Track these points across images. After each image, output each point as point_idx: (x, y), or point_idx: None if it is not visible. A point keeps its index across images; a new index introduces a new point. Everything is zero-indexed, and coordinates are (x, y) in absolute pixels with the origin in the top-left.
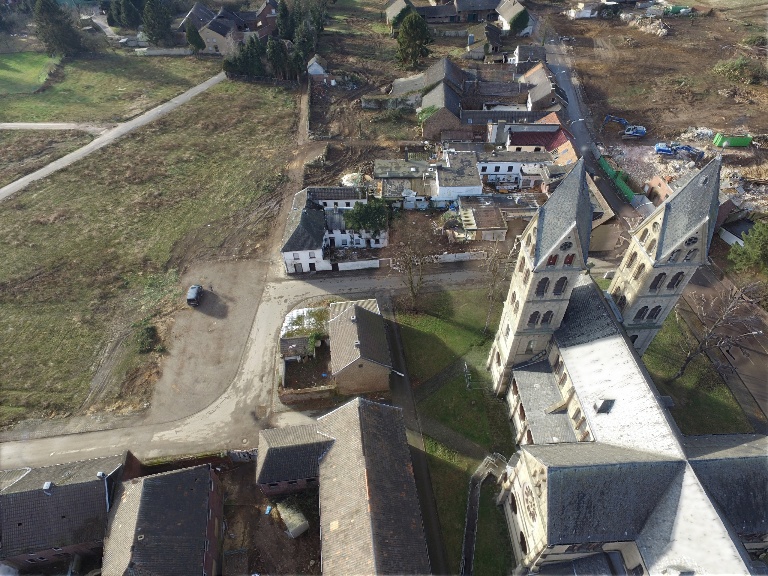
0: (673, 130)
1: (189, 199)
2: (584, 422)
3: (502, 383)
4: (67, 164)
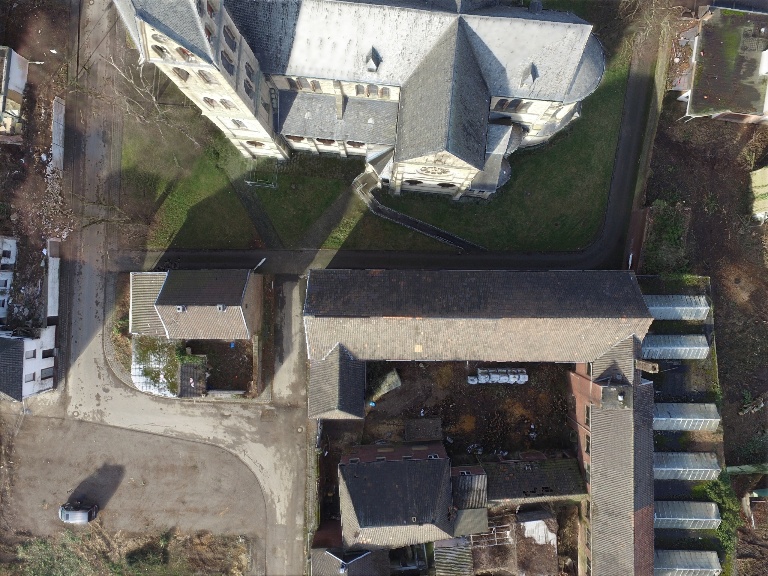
0: None
1: None
2: (370, 87)
3: (283, 150)
4: None
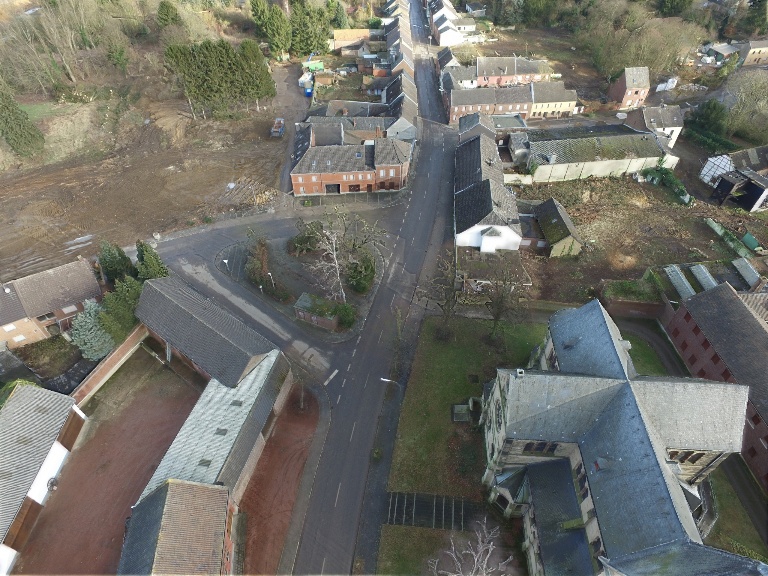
0: None
1: None
2: None
3: None
4: None
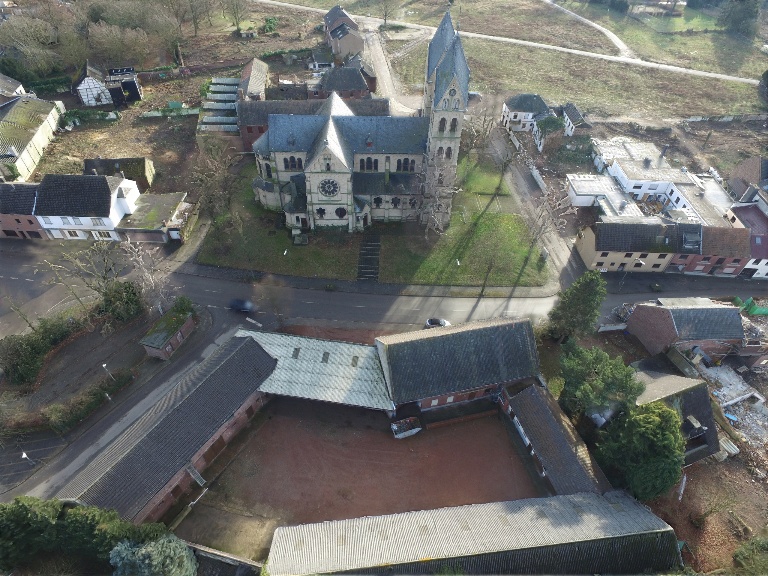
0: None
1: (562, 89)
2: None
3: None
4: (577, 53)
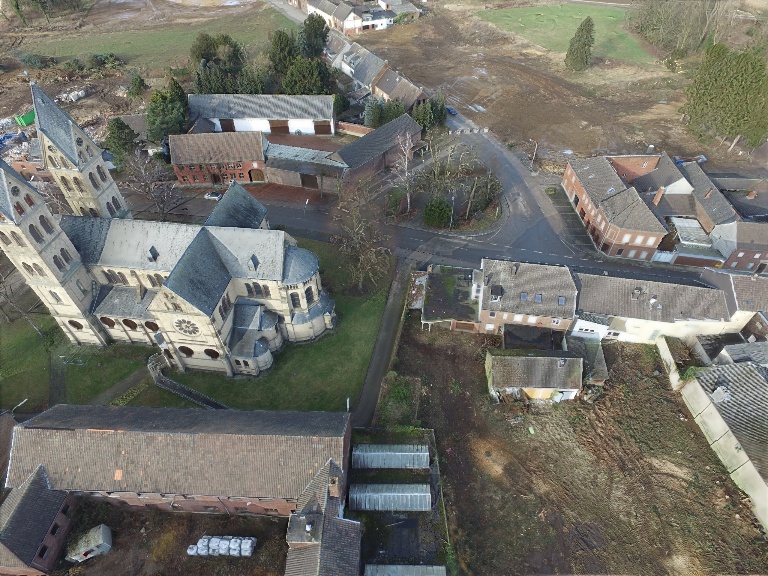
0: None
1: None
2: (158, 277)
3: (98, 332)
4: None
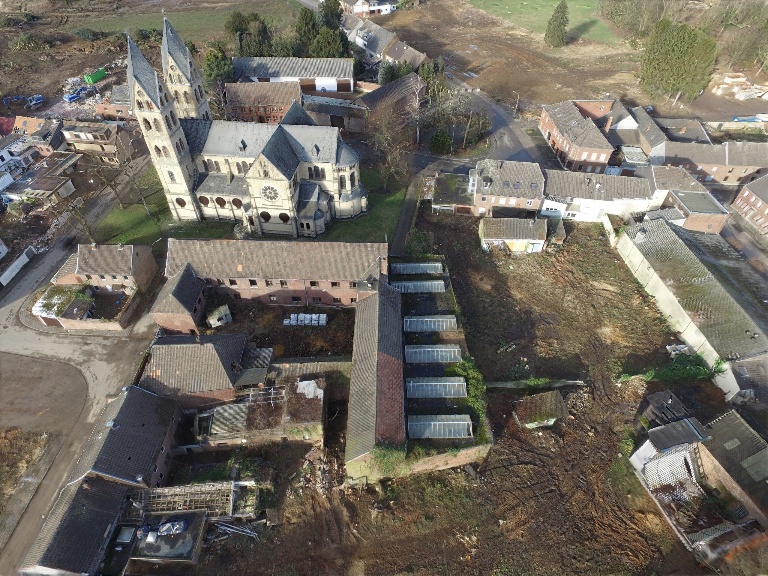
0: (54, 89)
1: None
2: (244, 165)
3: (196, 208)
4: None
